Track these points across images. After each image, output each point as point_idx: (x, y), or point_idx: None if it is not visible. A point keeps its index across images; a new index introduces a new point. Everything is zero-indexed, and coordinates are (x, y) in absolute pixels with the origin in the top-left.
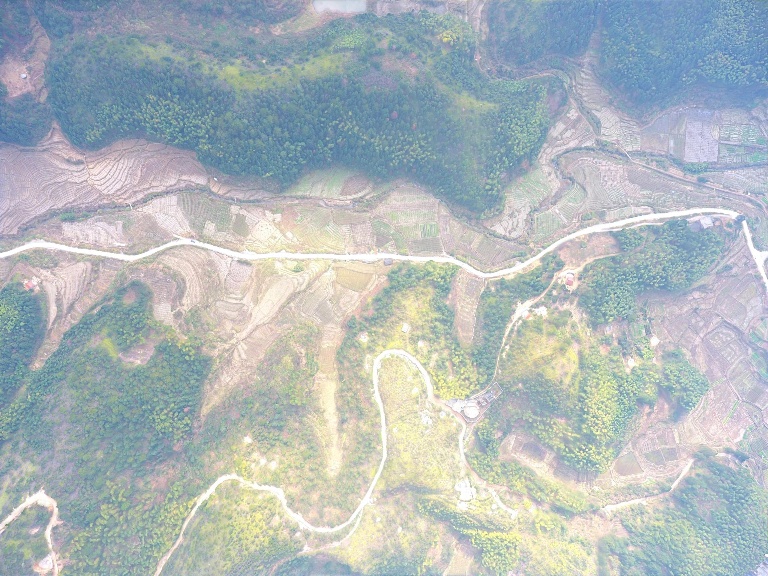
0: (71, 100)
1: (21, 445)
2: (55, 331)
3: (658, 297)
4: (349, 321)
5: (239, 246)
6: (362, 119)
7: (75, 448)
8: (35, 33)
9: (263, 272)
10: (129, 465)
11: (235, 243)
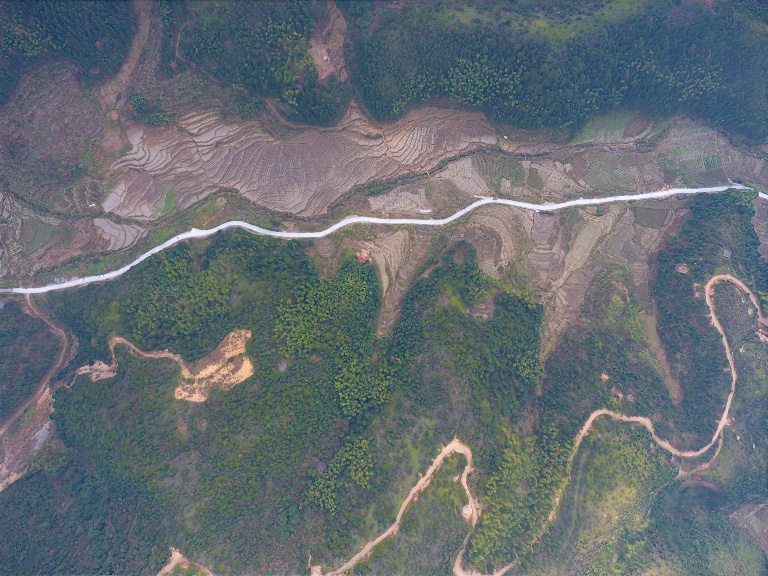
0: (382, 74)
1: (407, 404)
2: (388, 299)
3: None
4: (661, 256)
5: (537, 199)
6: (659, 57)
7: (468, 398)
8: (332, 15)
9: (569, 220)
10: (510, 411)
11: (532, 196)
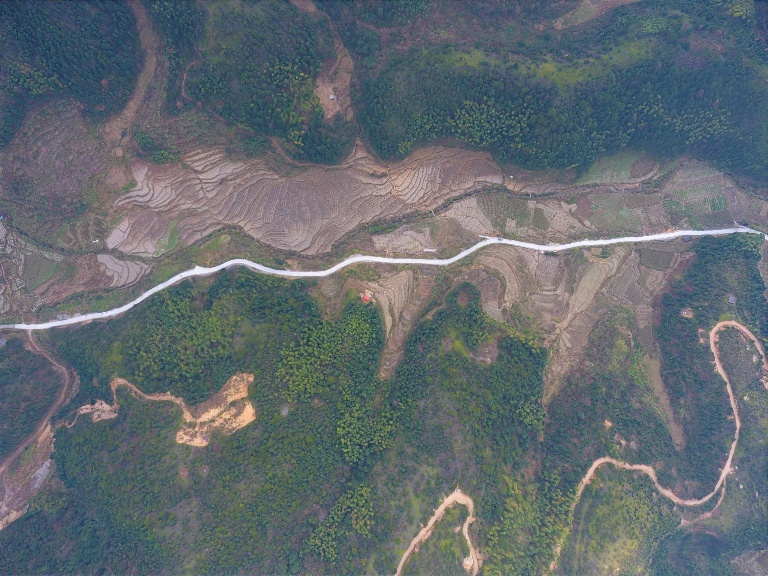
0: (388, 115)
1: (409, 450)
2: (391, 340)
3: None
4: (666, 299)
5: (542, 239)
6: (667, 101)
7: (471, 447)
8: (338, 54)
9: (574, 261)
10: (512, 459)
11: (537, 237)
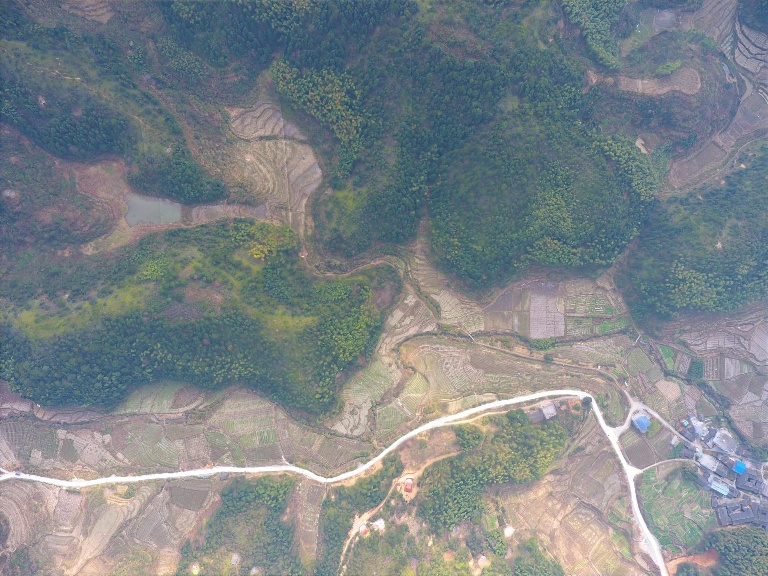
0: None
1: None
2: None
3: (510, 485)
4: (182, 548)
5: (68, 473)
6: (174, 347)
7: None
8: None
9: (91, 502)
10: None
11: (63, 470)
